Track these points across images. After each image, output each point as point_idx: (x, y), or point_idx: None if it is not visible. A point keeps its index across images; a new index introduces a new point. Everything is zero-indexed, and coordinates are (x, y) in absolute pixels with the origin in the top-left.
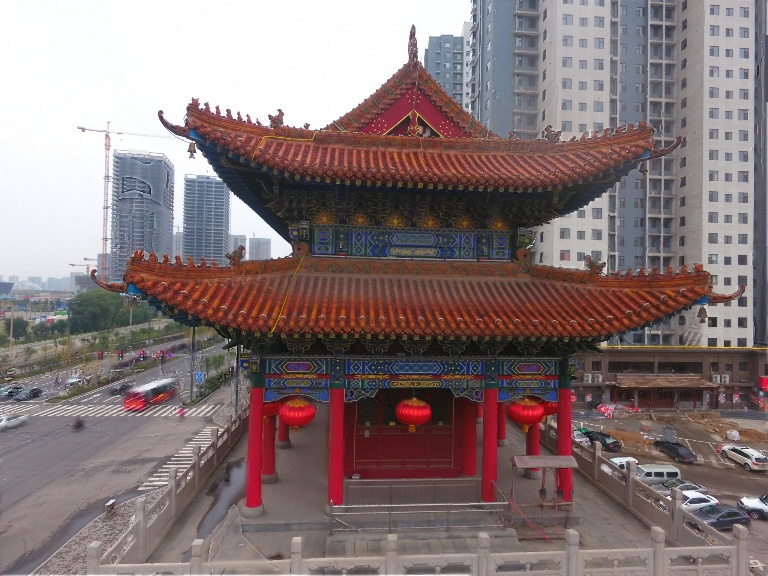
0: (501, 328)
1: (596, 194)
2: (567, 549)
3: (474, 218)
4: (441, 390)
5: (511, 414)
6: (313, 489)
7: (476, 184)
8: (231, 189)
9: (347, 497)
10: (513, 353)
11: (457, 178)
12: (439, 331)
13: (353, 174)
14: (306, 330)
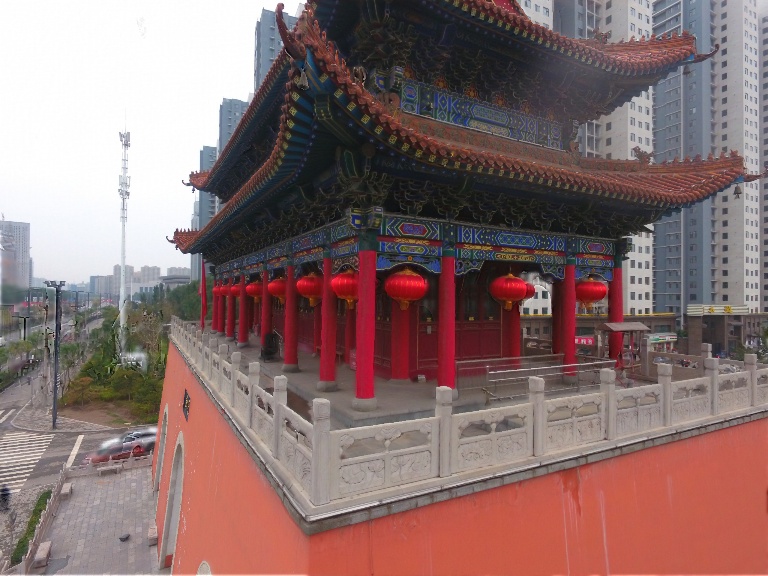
0: (627, 185)
1: (629, 98)
2: (710, 374)
3: (536, 105)
4: (533, 266)
5: (581, 292)
6: (391, 390)
7: (581, 52)
8: (316, 6)
9: (458, 381)
10: (584, 233)
11: (570, 41)
12: (585, 181)
13: (490, 7)
14: (481, 161)
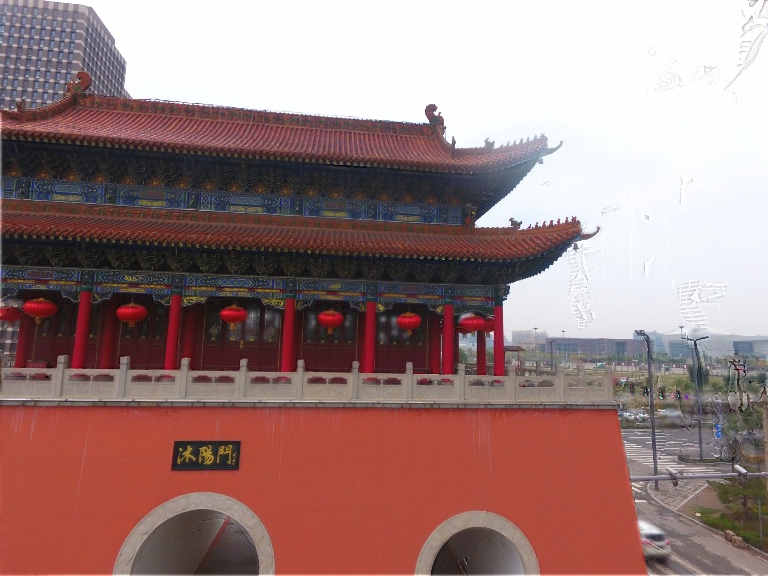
0: None
1: None
2: None
3: None
4: None
5: None
6: None
7: None
8: None
9: None
10: None
11: None
12: None
13: None
14: None
